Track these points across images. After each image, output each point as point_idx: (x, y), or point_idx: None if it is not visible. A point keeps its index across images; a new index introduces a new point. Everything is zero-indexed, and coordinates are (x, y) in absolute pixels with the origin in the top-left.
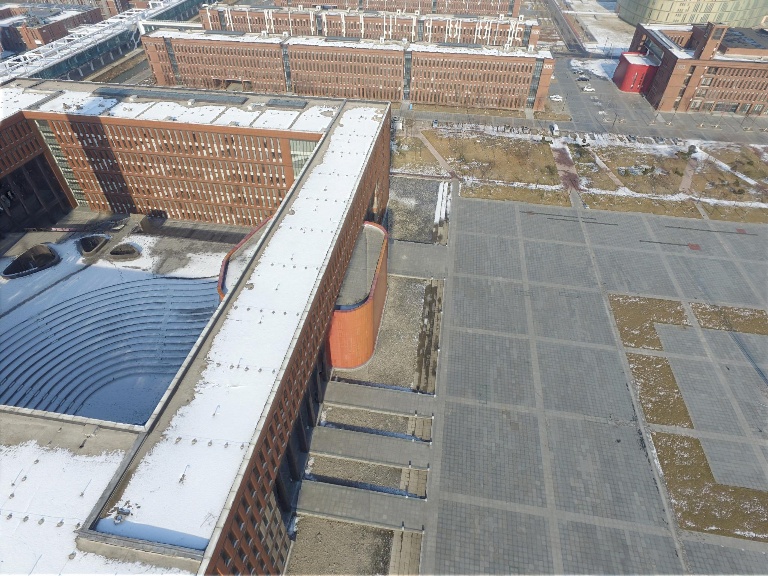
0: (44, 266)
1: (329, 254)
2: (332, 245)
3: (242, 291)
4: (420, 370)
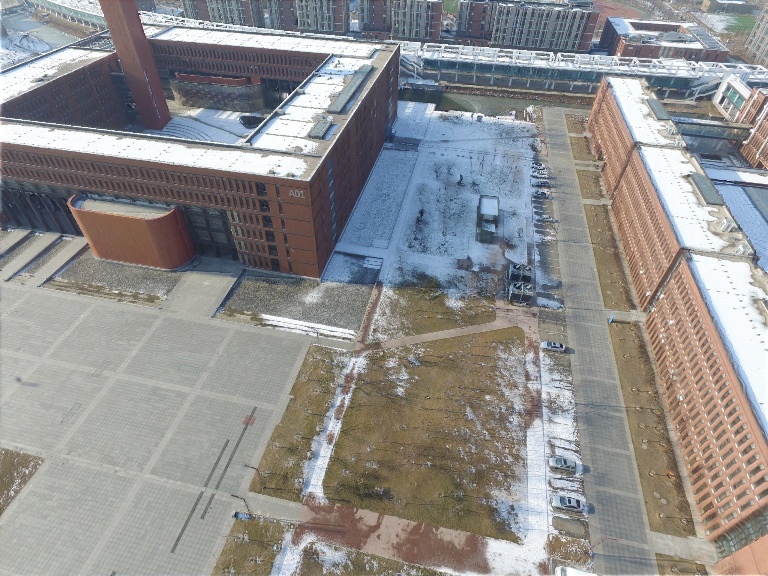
0: (244, 124)
1: (47, 147)
2: (56, 148)
3: (49, 128)
4: (68, 283)
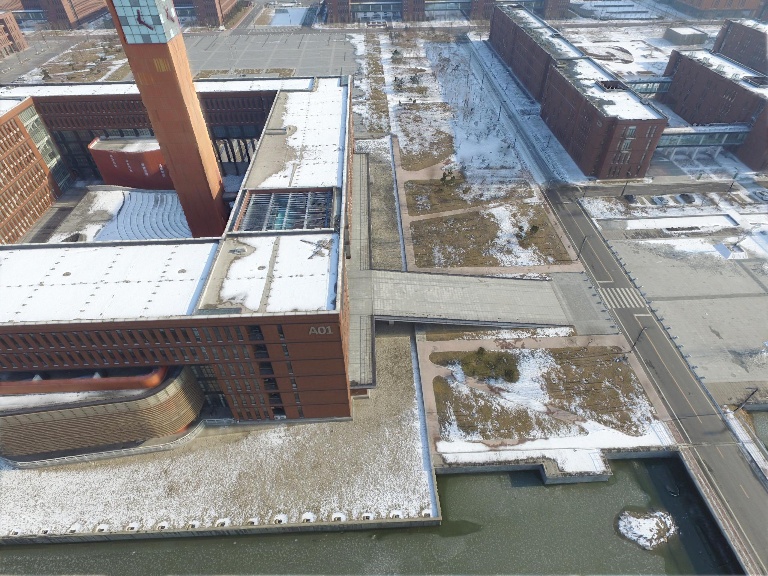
0: None
1: None
2: None
3: None
4: None
